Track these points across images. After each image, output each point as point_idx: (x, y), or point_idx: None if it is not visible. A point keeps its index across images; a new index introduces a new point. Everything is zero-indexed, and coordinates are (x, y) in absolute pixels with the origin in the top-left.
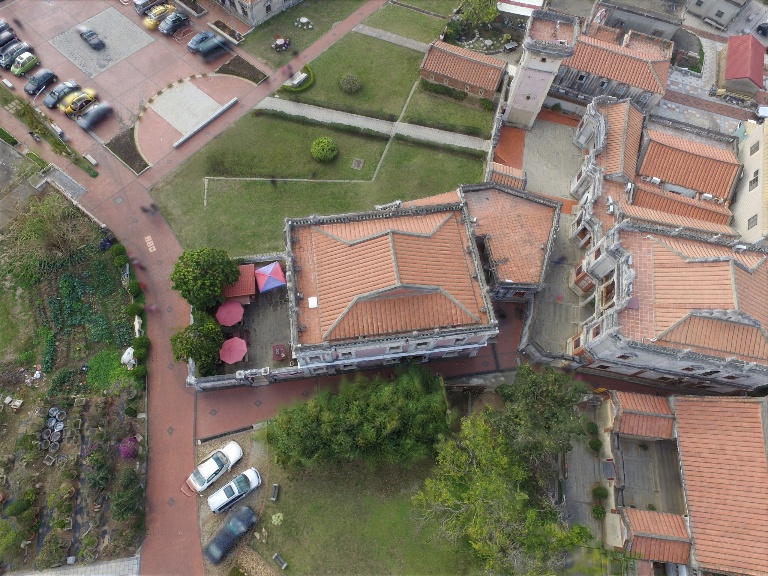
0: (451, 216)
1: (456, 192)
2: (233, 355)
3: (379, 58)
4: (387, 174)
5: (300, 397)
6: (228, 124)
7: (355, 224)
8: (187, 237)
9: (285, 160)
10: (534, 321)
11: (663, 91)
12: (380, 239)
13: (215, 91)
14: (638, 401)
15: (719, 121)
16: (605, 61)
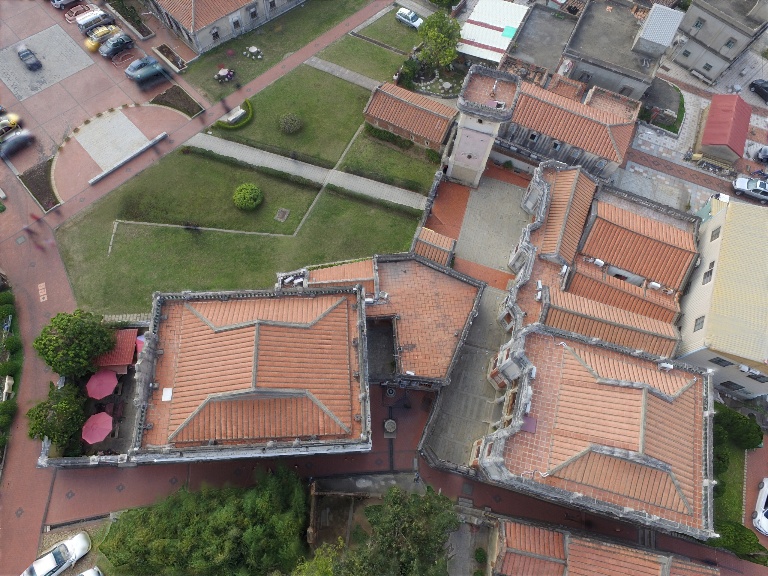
0: (342, 301)
1: (372, 261)
2: (95, 434)
3: (327, 96)
4: (311, 229)
5: (167, 484)
6: (152, 161)
7: (232, 303)
8: (83, 287)
9: (205, 205)
10: (433, 421)
11: (620, 160)
12: (246, 330)
13: (145, 123)
14: (529, 537)
15: (690, 191)
16: (559, 121)
